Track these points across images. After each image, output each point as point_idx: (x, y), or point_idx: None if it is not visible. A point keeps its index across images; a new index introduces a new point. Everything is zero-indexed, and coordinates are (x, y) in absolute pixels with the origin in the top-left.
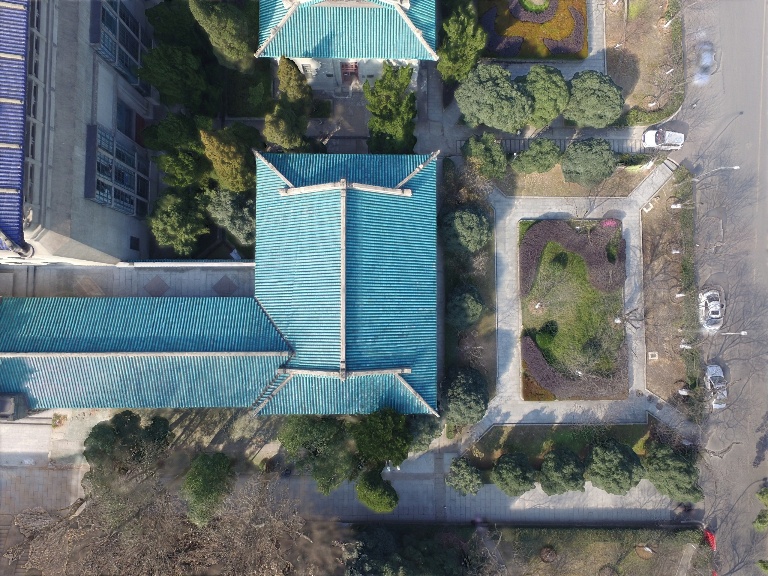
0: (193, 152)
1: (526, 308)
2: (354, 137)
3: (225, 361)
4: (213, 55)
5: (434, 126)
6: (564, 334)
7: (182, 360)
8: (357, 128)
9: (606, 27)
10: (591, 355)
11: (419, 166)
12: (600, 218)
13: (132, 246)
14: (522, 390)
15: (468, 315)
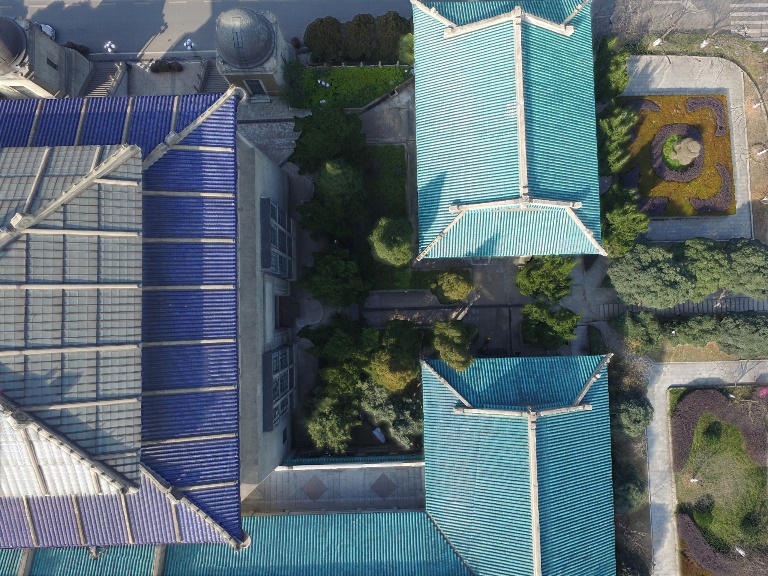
0: (355, 358)
1: (680, 481)
2: (494, 305)
3: None
4: (354, 234)
5: (576, 290)
6: (721, 508)
7: None
8: (497, 296)
9: (751, 178)
10: (754, 534)
11: (596, 376)
12: (753, 382)
13: (283, 439)
14: (680, 569)
15: (632, 505)
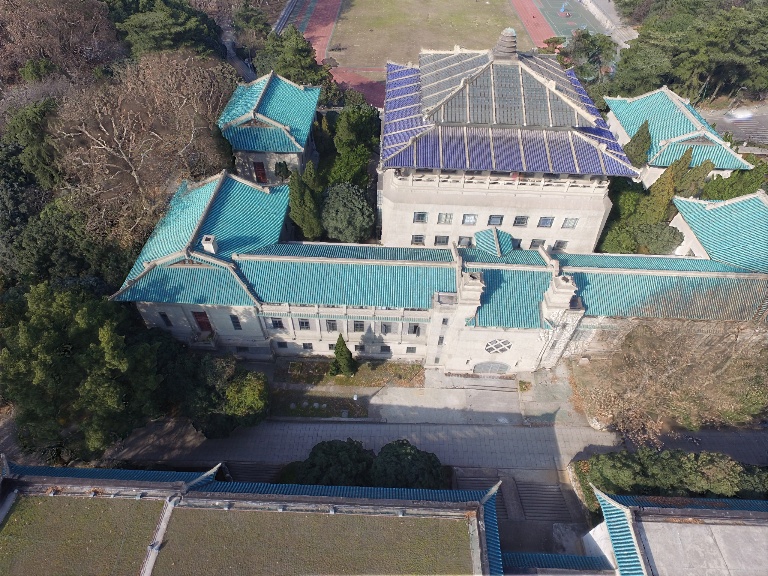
0: None
1: None
2: None
3: (726, 282)
4: None
5: None
6: None
7: (695, 280)
8: None
9: None
10: None
11: None
12: None
13: None
14: None
15: None
